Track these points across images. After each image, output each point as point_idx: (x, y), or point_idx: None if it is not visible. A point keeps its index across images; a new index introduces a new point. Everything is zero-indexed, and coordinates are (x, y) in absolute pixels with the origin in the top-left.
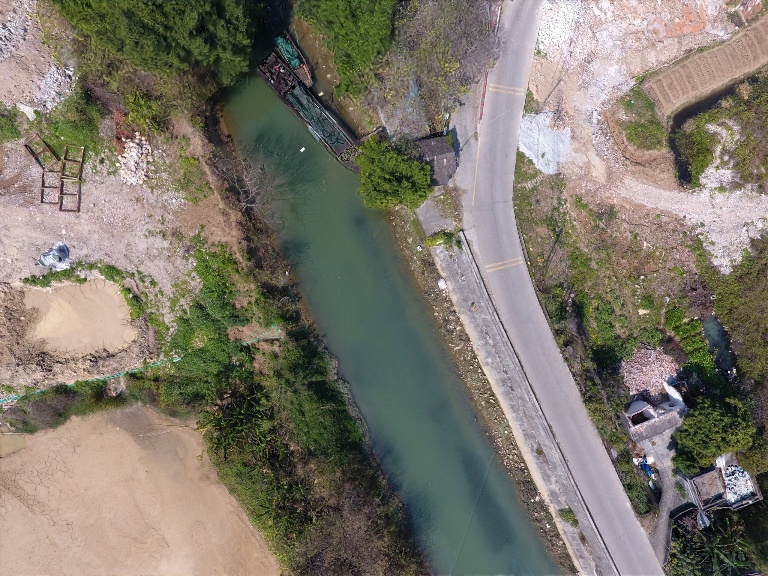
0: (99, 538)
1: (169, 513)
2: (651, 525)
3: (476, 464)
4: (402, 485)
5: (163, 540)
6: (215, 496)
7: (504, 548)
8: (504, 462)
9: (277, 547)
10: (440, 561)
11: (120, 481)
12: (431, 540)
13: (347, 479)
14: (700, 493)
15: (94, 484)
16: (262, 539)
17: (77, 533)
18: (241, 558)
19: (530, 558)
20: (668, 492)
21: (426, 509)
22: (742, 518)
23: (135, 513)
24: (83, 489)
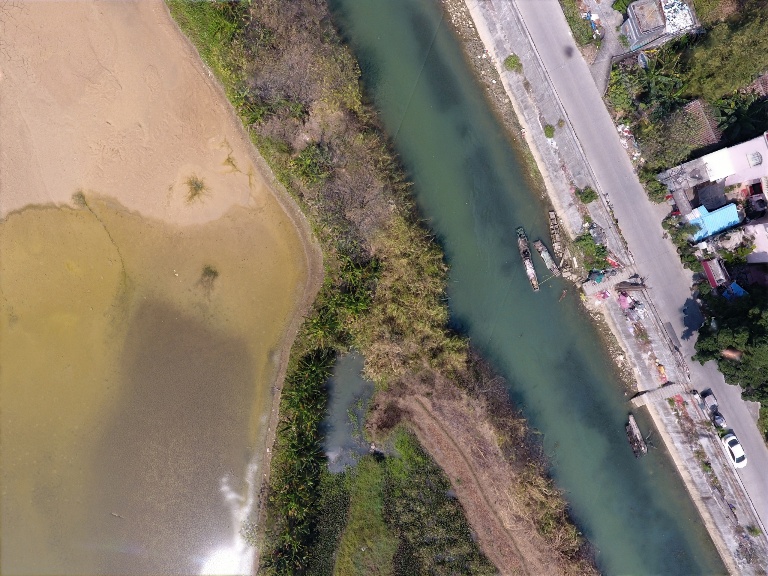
0: (54, 76)
1: (123, 56)
2: (592, 55)
3: (425, 23)
4: (352, 38)
5: (117, 82)
6: (168, 42)
7: (451, 106)
8: (452, 20)
9: (225, 58)
10: (388, 115)
11: (75, 21)
12: (379, 93)
13: (295, 3)
14: (640, 24)
15: (50, 22)
16: (214, 86)
17: (32, 69)
18: (193, 104)
19: (477, 118)
20: (611, 42)
21: (375, 63)
22: (682, 61)
23: (90, 53)
24: (39, 26)
